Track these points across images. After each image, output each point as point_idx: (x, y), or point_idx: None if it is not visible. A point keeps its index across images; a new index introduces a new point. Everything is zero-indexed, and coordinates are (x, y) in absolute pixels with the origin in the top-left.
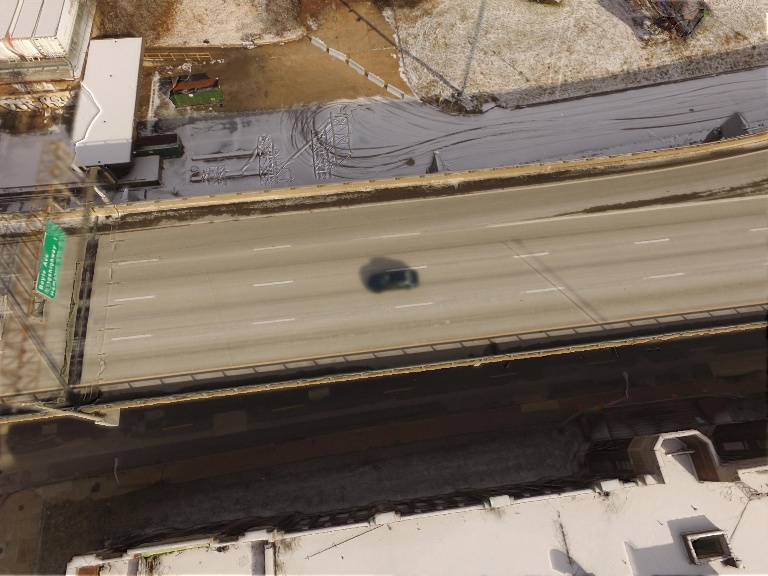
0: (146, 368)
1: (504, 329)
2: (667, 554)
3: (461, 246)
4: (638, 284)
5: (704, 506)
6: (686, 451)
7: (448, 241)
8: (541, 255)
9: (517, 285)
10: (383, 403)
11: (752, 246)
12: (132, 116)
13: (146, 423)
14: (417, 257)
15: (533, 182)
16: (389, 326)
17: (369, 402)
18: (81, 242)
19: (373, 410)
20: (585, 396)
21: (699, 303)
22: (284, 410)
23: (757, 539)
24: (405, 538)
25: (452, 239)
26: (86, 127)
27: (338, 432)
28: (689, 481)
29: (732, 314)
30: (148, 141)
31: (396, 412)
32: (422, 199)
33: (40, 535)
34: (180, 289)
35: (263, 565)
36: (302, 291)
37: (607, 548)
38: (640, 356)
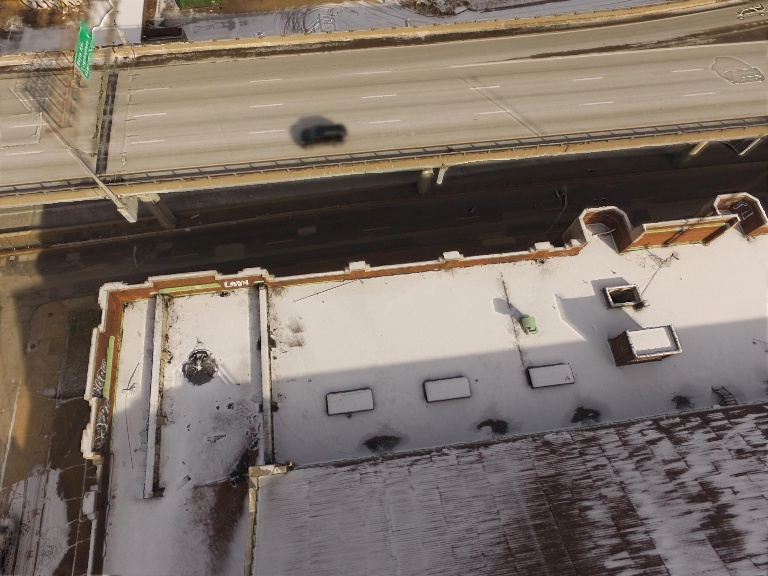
0: (160, 163)
1: (460, 139)
2: (589, 303)
3: (426, 81)
4: (574, 109)
5: (622, 271)
6: (609, 231)
7: (415, 77)
8: (493, 87)
9: (472, 108)
10: (363, 239)
11: (673, 83)
12: (141, 15)
13: (157, 253)
14: (388, 88)
15: (489, 36)
16: (363, 136)
17: (351, 238)
18: (103, 75)
19: (354, 244)
20: (538, 234)
21: (625, 123)
22: (277, 243)
23: (664, 294)
24: (375, 289)
25: (418, 75)
26: (101, 19)
27: (324, 260)
28: (611, 254)
29: (652, 131)
30: (156, 33)
31: (374, 245)
32: (394, 47)
33: (67, 335)
34: (188, 109)
35: (258, 306)
36: (291, 111)
37: (540, 298)
38: (588, 204)
